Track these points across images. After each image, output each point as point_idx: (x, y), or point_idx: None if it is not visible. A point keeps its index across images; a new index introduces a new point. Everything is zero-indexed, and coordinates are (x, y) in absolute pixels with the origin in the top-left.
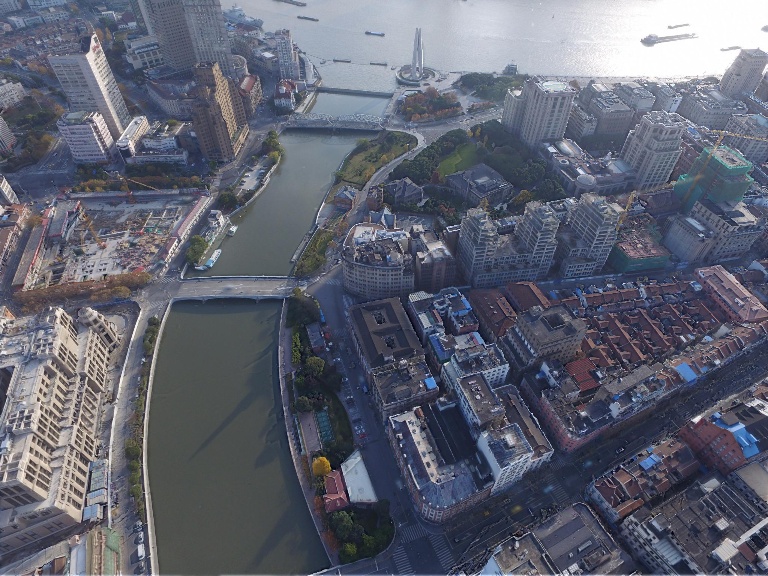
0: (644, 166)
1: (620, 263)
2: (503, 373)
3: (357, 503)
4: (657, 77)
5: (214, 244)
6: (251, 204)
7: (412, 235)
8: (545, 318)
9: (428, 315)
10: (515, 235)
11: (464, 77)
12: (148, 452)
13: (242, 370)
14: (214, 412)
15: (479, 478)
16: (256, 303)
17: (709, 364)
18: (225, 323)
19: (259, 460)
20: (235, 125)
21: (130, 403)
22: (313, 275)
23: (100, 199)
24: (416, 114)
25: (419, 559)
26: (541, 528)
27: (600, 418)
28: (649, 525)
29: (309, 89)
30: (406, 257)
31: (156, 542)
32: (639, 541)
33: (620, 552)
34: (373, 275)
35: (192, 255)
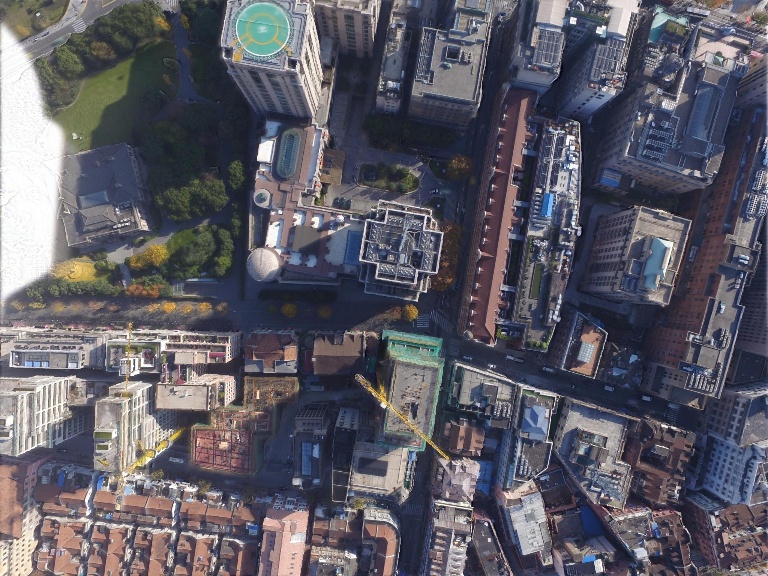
0: None
1: None
2: None
3: None
4: None
5: None
6: None
7: None
8: None
9: None
10: None
11: None
12: None
13: None
14: None
15: None
16: None
17: None
18: None
19: None
20: None
21: None
22: None
23: None
24: None
25: None
26: None
27: None
28: None
29: None
30: None
31: None
32: None
33: None
34: None
35: None
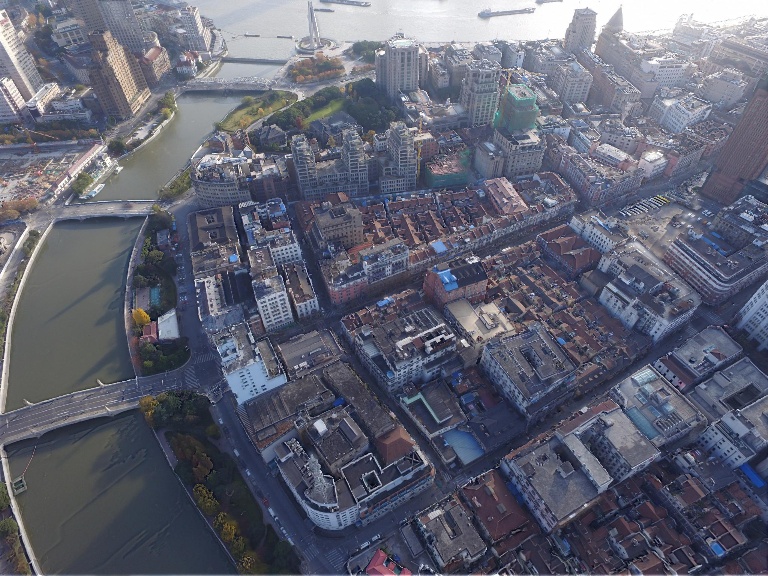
0: (472, 107)
1: (430, 181)
2: (296, 252)
3: (165, 341)
4: (528, 40)
5: (100, 180)
6: (140, 151)
7: (254, 162)
8: (334, 211)
9: (249, 216)
10: (341, 160)
11: (354, 45)
12: (16, 320)
13: (101, 265)
14: (72, 292)
15: (248, 313)
16: (125, 220)
17: (462, 242)
18: (97, 236)
19: (100, 321)
20: (135, 88)
21: (6, 289)
22: (177, 199)
23: (9, 150)
24: (300, 76)
25: (203, 372)
26: (288, 343)
27: (355, 275)
28: (360, 333)
29: (213, 59)
30: (241, 175)
31: (9, 371)
32: (359, 349)
33: (341, 354)
34: (214, 191)
35: (76, 187)
